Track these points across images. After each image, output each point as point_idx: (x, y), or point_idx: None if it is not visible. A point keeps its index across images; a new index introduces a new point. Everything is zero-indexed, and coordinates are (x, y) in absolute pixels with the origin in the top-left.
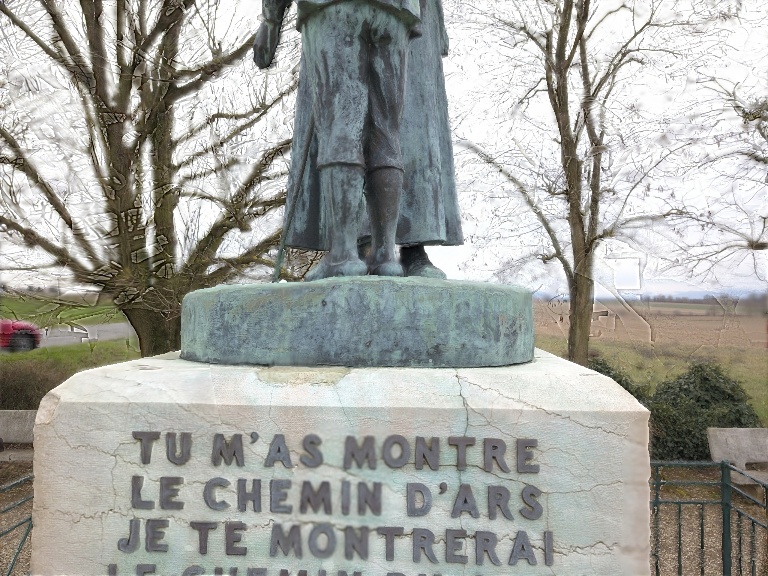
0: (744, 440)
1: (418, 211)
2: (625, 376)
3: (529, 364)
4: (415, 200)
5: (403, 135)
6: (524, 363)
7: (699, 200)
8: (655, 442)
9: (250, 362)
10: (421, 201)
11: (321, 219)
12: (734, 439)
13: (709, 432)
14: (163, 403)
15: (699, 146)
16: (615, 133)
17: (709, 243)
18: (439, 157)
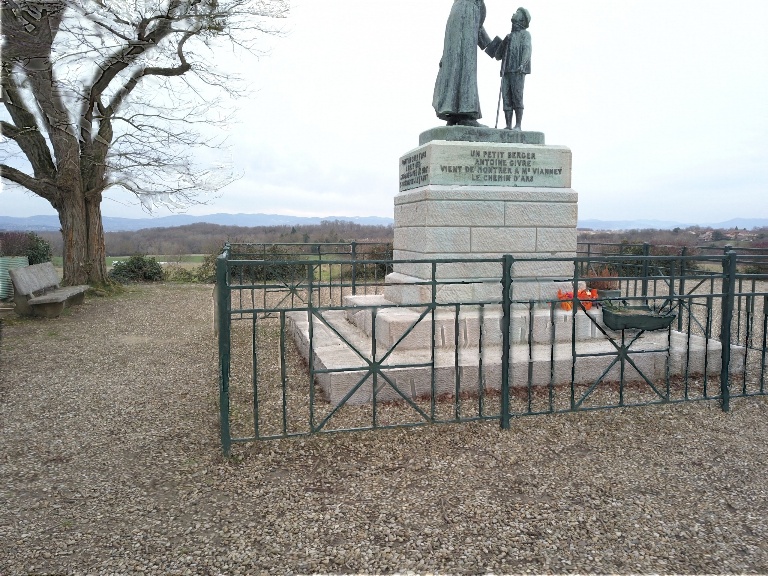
0: (26, 276)
1: None
2: None
3: None
4: None
5: None
6: None
7: (89, 79)
8: None
9: None
10: None
11: None
12: (23, 276)
13: (13, 272)
14: None
15: (152, 50)
16: (126, 16)
17: None
18: None
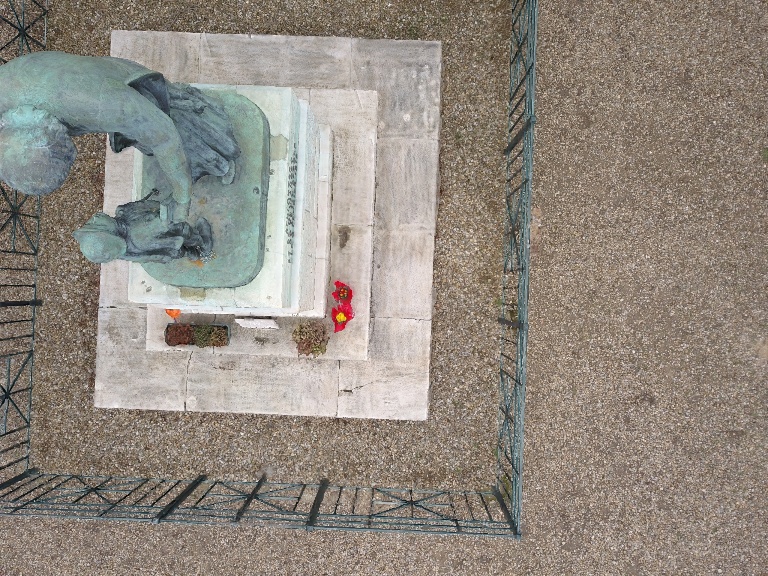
0: None
1: None
2: None
3: (258, 276)
4: None
5: None
6: (257, 275)
7: None
8: None
9: None
10: None
11: None
12: None
13: None
14: None
15: None
16: None
17: None
18: (212, 155)
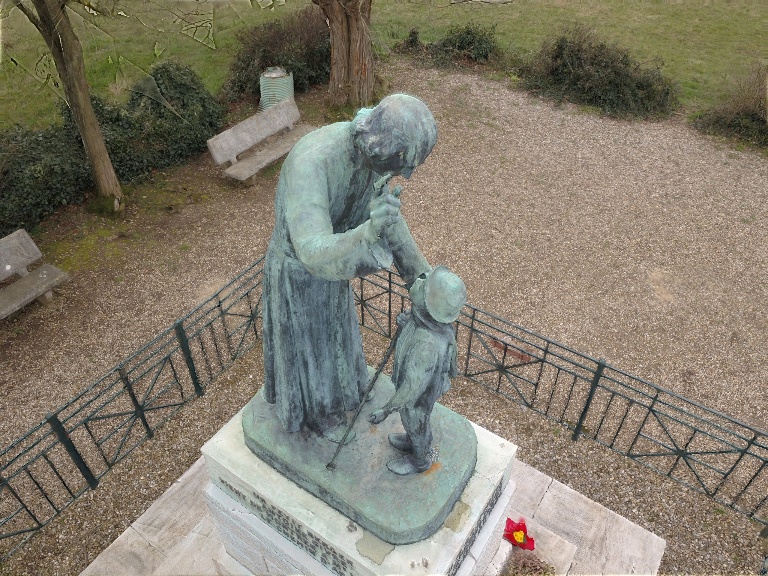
0: (231, 140)
1: (362, 374)
2: (123, 111)
3: None
4: (360, 371)
5: (353, 348)
6: None
7: None
8: (161, 155)
9: (438, 528)
10: (362, 369)
11: (307, 405)
12: (225, 142)
13: (209, 145)
14: (448, 567)
15: None
16: None
17: (203, 12)
18: None
